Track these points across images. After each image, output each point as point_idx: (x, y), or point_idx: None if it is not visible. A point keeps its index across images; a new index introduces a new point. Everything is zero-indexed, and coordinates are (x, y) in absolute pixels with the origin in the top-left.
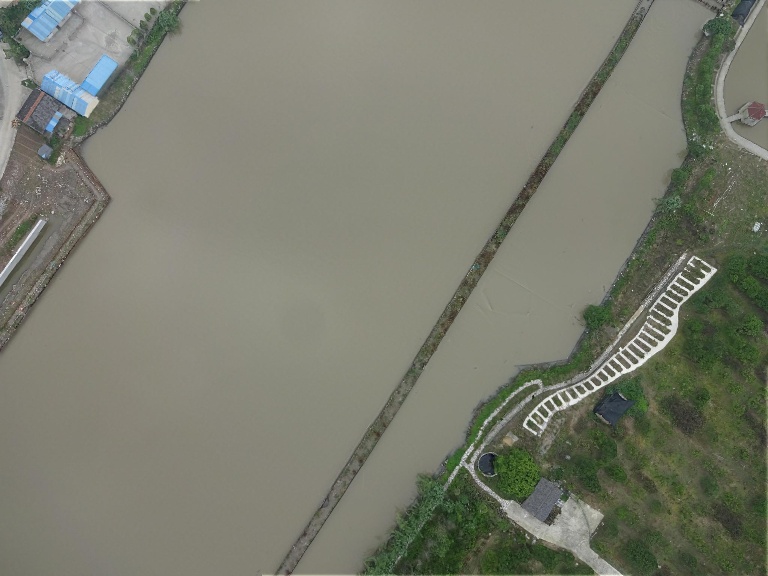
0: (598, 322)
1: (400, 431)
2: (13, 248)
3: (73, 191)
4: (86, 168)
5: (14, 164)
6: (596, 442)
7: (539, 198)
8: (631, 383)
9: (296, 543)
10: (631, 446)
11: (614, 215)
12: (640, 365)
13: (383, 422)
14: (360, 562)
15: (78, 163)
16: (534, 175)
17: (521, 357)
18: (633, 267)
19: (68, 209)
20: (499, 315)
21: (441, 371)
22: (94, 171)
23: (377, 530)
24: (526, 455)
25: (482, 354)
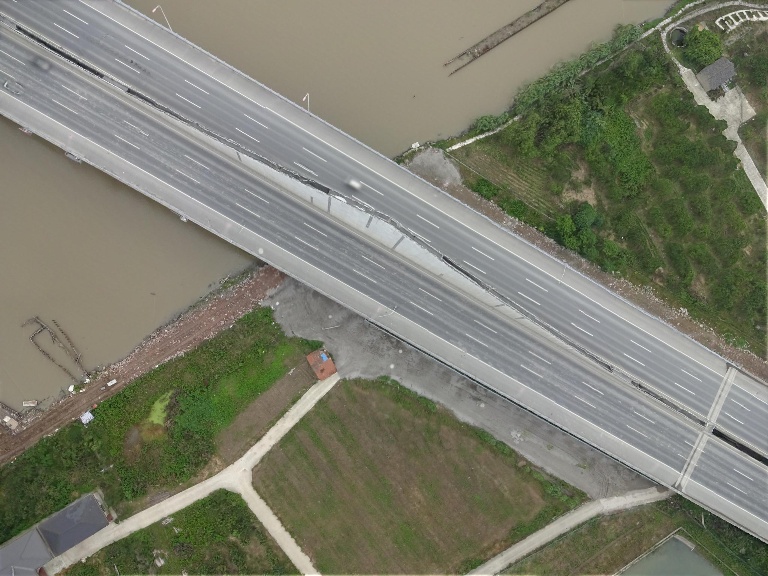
0: None
1: None
2: None
3: None
4: None
5: None
6: None
7: None
8: None
9: (502, 28)
10: None
11: None
12: None
13: None
14: (545, 70)
15: None
16: None
17: None
18: None
19: None
20: None
21: None
22: None
23: (566, 55)
24: None
25: None
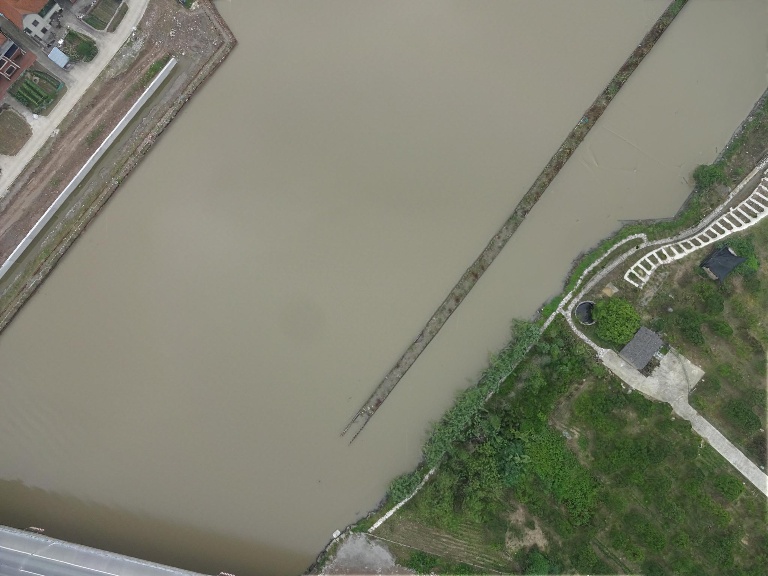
0: (709, 179)
1: (498, 276)
2: (146, 85)
3: (203, 35)
4: (217, 13)
5: (153, 7)
6: (701, 295)
7: (653, 58)
8: (742, 240)
9: (389, 374)
10: (739, 303)
11: (731, 79)
12: (752, 224)
13: (482, 265)
14: (450, 400)
15: (210, 8)
16: (650, 34)
17: (625, 213)
18: (749, 128)
19: (197, 51)
20: (605, 170)
21: (542, 221)
22: (223, 17)
23: (468, 372)
24: (627, 303)
25: (585, 207)
